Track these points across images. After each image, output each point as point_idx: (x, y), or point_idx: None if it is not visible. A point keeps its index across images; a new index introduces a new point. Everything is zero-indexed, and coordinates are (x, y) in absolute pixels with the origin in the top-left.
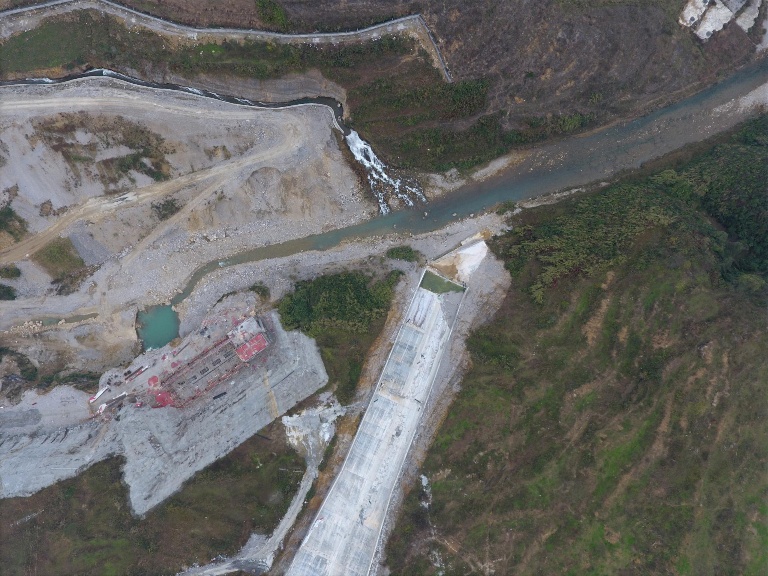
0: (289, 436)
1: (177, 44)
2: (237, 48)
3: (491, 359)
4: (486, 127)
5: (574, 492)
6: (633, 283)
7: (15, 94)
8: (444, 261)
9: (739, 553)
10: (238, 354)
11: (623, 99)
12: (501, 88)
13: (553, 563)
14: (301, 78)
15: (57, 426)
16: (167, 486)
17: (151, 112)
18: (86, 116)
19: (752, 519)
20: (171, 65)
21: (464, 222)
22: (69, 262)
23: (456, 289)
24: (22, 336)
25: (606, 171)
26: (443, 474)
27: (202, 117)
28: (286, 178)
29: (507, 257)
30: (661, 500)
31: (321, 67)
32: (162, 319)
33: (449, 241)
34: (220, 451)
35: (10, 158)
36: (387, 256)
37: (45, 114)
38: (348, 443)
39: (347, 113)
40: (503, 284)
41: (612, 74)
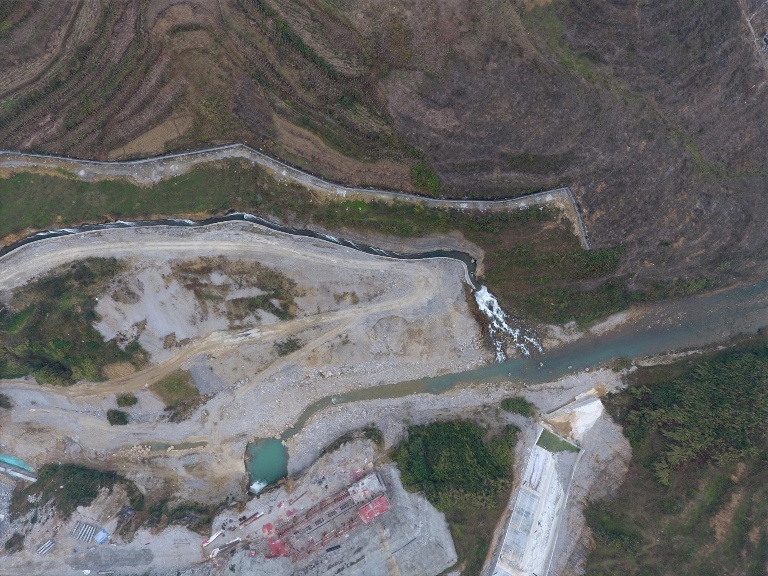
0: None
1: (324, 199)
2: (384, 208)
3: (614, 540)
4: (613, 288)
5: None
6: (767, 482)
7: (157, 235)
8: (559, 417)
9: None
10: (360, 515)
11: (748, 266)
12: (634, 254)
13: None
14: (442, 237)
15: (169, 568)
16: None
17: (288, 259)
18: (225, 260)
19: None
20: (316, 218)
21: (579, 376)
22: (185, 391)
23: (570, 449)
24: (130, 461)
25: (724, 334)
26: None
27: (337, 266)
28: (413, 328)
29: (626, 424)
30: None
31: (465, 230)
32: (270, 451)
33: (564, 395)
34: None
35: (144, 295)
36: (502, 408)
37: (185, 257)
38: None
39: (481, 271)
40: (623, 454)
41: (743, 244)
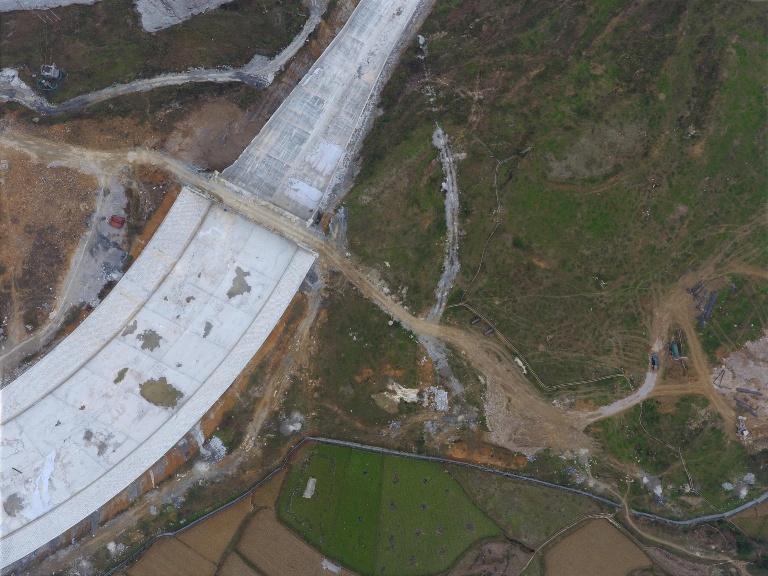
0: None
1: None
2: None
3: None
4: None
5: (564, 39)
6: None
7: None
8: None
9: (717, 71)
10: None
11: None
12: None
13: (539, 93)
14: None
15: None
16: None
17: None
18: None
19: (732, 41)
20: None
21: None
22: None
23: None
24: None
25: None
26: (440, 35)
27: None
28: None
29: None
30: (646, 34)
31: None
32: None
33: None
34: None
35: None
36: None
37: None
38: (351, 12)
39: None
40: None
41: None
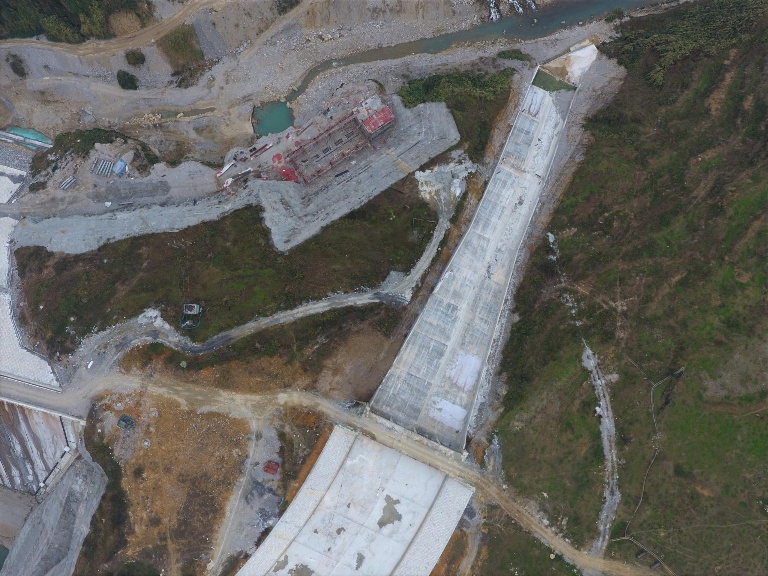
0: (421, 190)
1: None
2: None
3: (612, 134)
4: None
5: (703, 241)
6: (759, 54)
7: None
8: (555, 63)
9: None
10: (365, 125)
11: None
12: None
13: (684, 302)
14: None
15: (185, 198)
16: (304, 234)
17: None
18: None
19: None
20: None
21: (573, 29)
22: (190, 53)
23: (567, 88)
24: (143, 126)
25: None
26: (569, 232)
27: None
28: None
29: (621, 53)
30: None
31: None
32: (276, 117)
33: (559, 46)
34: (353, 205)
35: None
36: (499, 56)
37: None
38: (474, 207)
39: None
40: (618, 76)
41: None
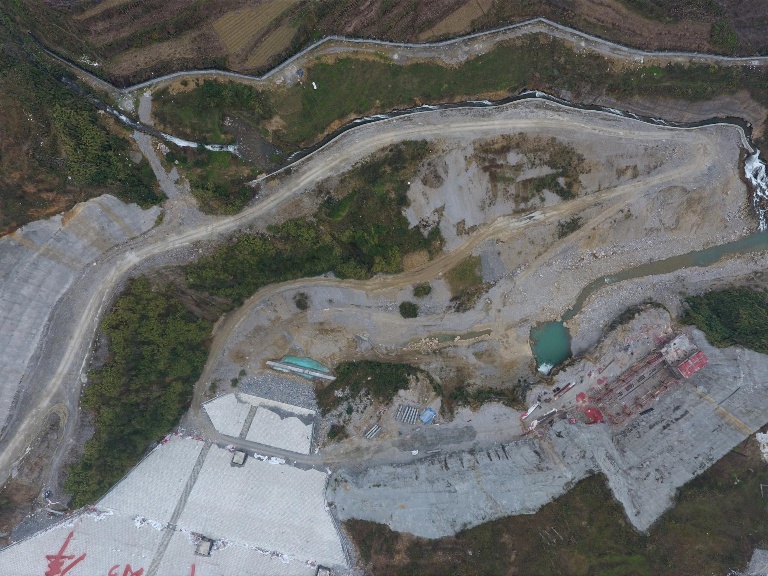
0: (764, 452)
1: (621, 67)
2: (680, 71)
3: None
4: None
5: None
6: None
7: (460, 116)
8: None
9: None
10: (681, 371)
11: None
12: None
13: None
14: (727, 99)
15: (492, 443)
16: (650, 502)
17: (580, 133)
18: (524, 138)
19: None
20: (613, 87)
21: None
22: (471, 280)
23: None
24: (422, 353)
25: None
26: None
27: (624, 138)
28: (694, 197)
29: None
30: None
31: (754, 89)
32: (550, 335)
33: None
34: (693, 467)
35: (447, 179)
36: None
37: (488, 136)
38: None
39: (760, 133)
40: None
41: None
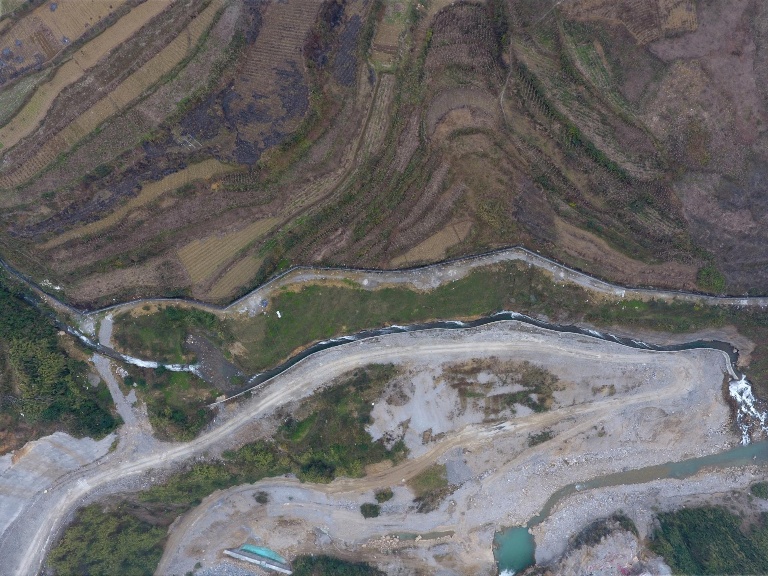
0: None
1: (601, 299)
2: (663, 306)
3: None
4: None
5: None
6: None
7: (430, 338)
8: None
9: None
10: None
11: None
12: None
13: None
14: (712, 331)
15: None
16: None
17: (555, 356)
18: (495, 361)
19: None
20: (591, 318)
21: None
22: (435, 483)
23: None
24: (381, 552)
25: None
26: None
27: (601, 361)
28: (672, 420)
29: None
30: None
31: (741, 326)
32: (515, 539)
33: None
34: None
35: (413, 397)
36: (754, 494)
37: (458, 359)
38: None
39: (747, 362)
40: None
41: None
